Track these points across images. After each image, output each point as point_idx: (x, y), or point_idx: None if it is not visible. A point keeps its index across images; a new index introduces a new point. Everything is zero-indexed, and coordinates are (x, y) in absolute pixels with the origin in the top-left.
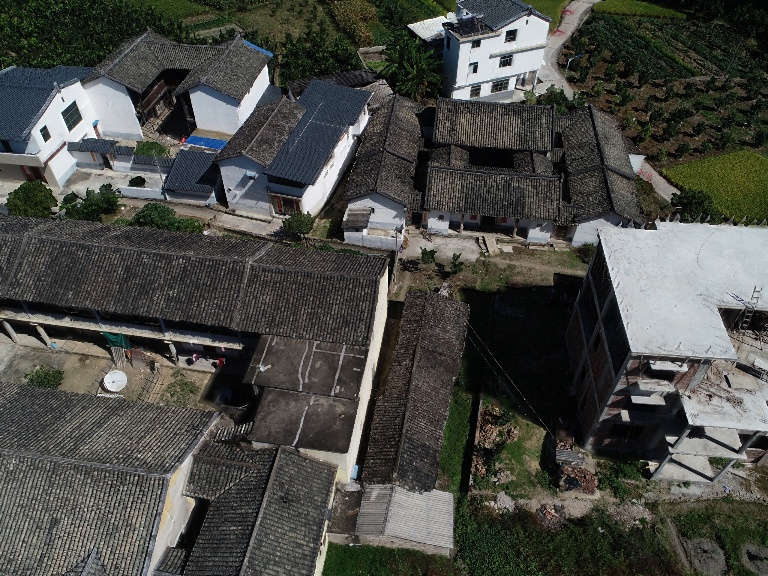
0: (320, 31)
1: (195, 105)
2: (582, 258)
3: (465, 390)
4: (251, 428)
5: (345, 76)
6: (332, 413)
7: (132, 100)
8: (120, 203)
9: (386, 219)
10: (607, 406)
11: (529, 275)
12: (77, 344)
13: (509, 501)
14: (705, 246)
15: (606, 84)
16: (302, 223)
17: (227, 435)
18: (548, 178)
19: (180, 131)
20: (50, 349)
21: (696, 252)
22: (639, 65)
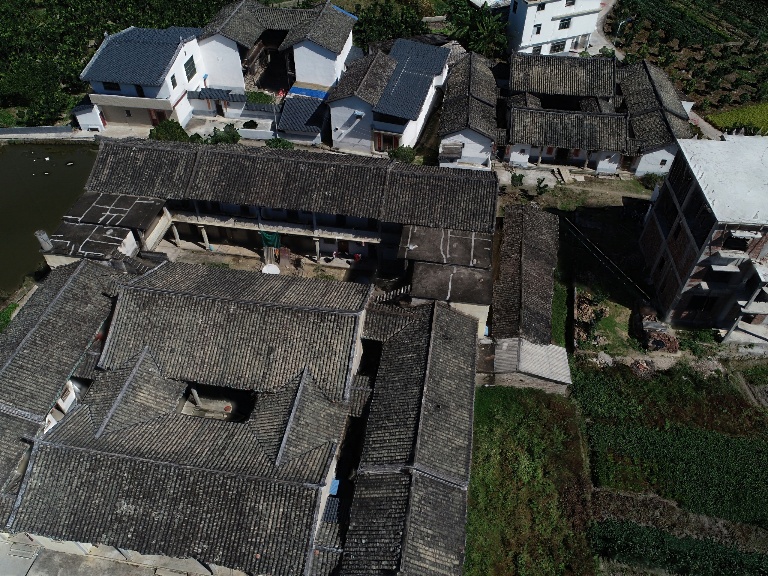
0: (384, 3)
1: (297, 59)
2: (645, 185)
3: (560, 281)
4: (410, 289)
5: (420, 38)
6: (473, 278)
7: (240, 56)
8: (237, 143)
9: (474, 153)
10: (690, 277)
11: (601, 198)
12: (230, 247)
13: (608, 358)
14: (767, 152)
15: (649, 48)
16: (406, 153)
17: (387, 297)
18: (616, 116)
19: (275, 86)
20: (207, 251)
21: (760, 156)
22: (678, 31)
